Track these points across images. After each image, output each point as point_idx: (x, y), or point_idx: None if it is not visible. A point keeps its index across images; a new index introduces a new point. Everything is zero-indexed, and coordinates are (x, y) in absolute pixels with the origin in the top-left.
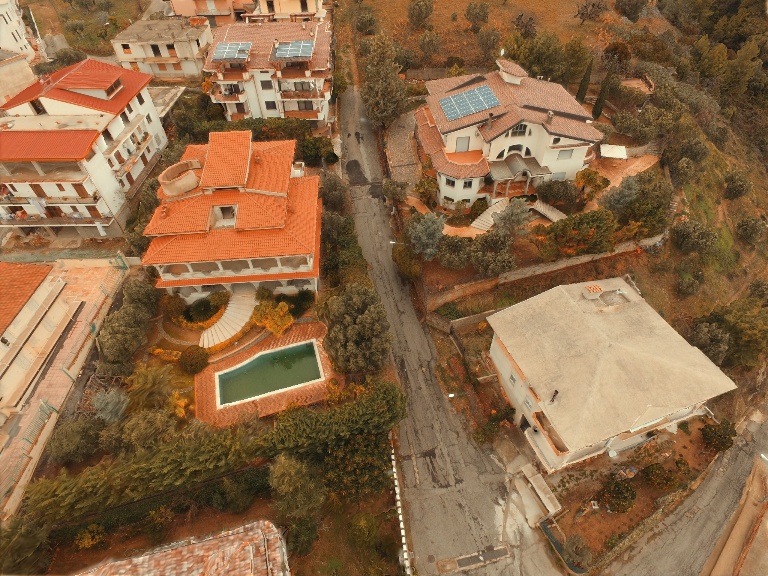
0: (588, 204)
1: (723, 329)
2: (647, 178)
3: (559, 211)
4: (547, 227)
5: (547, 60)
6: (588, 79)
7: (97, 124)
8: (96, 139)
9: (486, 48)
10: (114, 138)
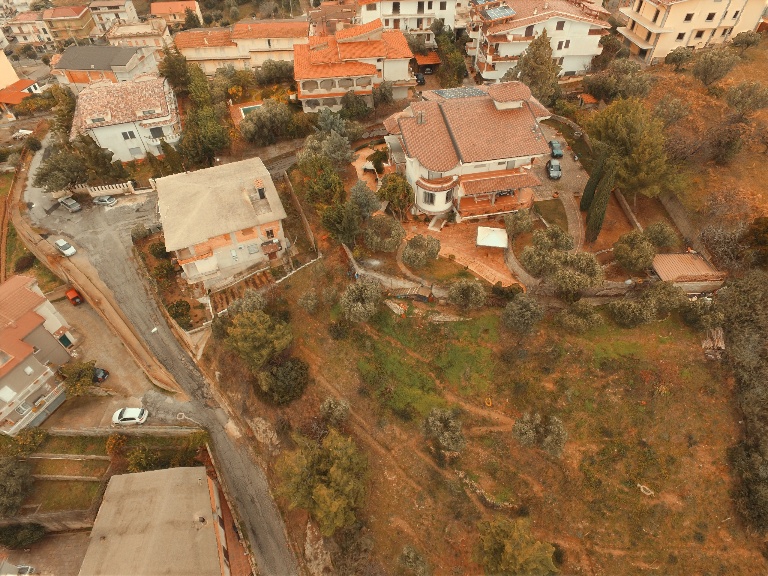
0: (406, 226)
1: None
2: (425, 243)
3: (388, 203)
4: (323, 161)
5: (625, 147)
6: (602, 183)
7: None
8: (385, 4)
9: (652, 117)
10: (402, 13)
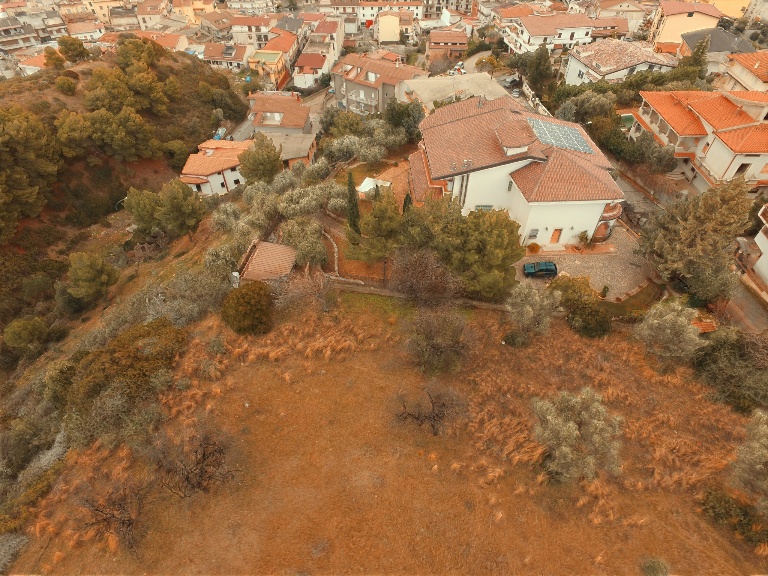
0: None
1: (363, 132)
2: None
3: None
4: None
5: None
6: None
7: None
8: None
9: None
10: None
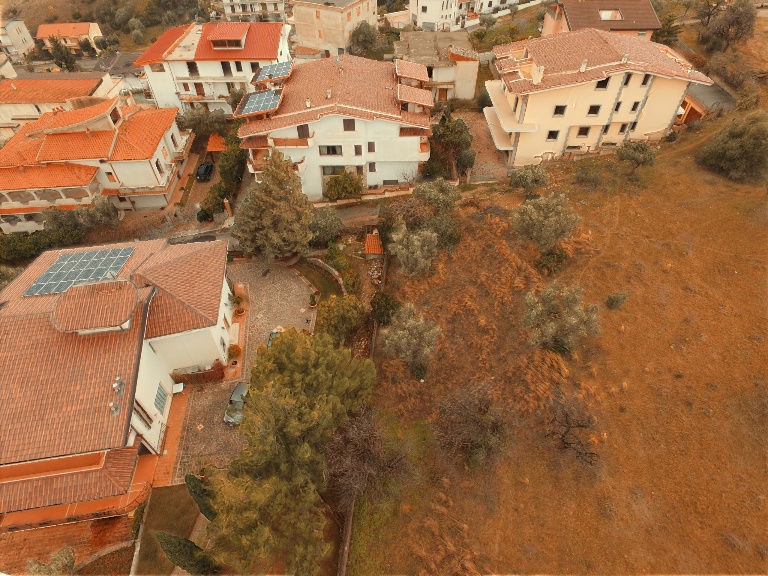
0: None
1: None
2: None
3: None
4: None
5: None
6: None
7: (180, 56)
8: (175, 64)
9: None
10: (203, 76)
